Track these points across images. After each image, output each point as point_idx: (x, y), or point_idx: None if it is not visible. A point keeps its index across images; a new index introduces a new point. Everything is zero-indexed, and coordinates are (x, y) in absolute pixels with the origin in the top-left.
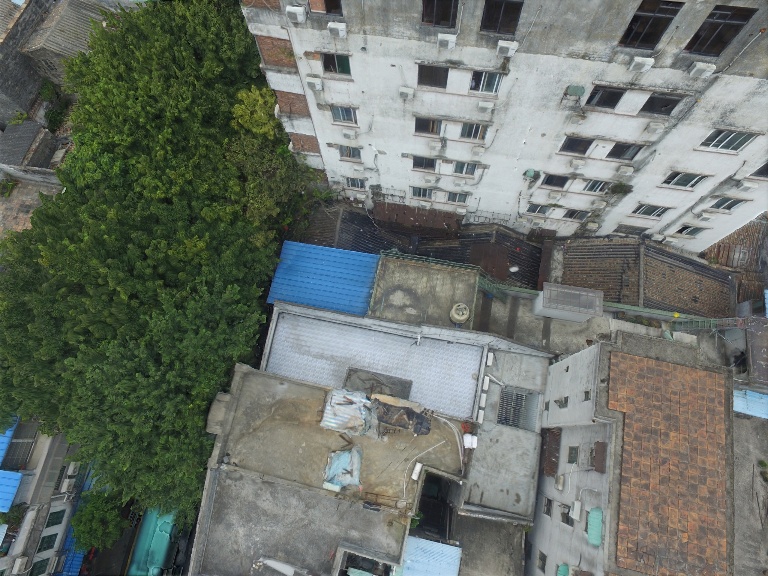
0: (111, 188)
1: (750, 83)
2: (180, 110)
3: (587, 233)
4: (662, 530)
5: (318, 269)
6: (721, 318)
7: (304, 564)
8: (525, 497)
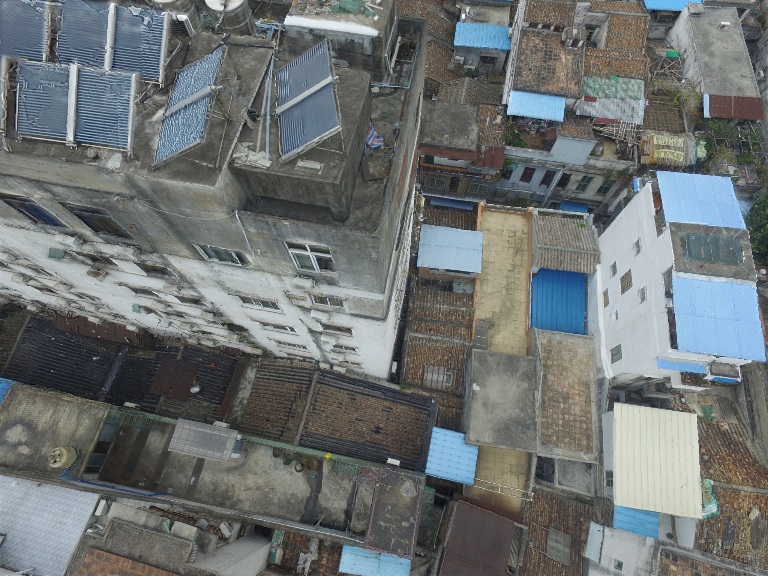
0: None
1: (197, 263)
2: None
3: (267, 354)
4: None
5: None
6: (362, 465)
7: None
8: None
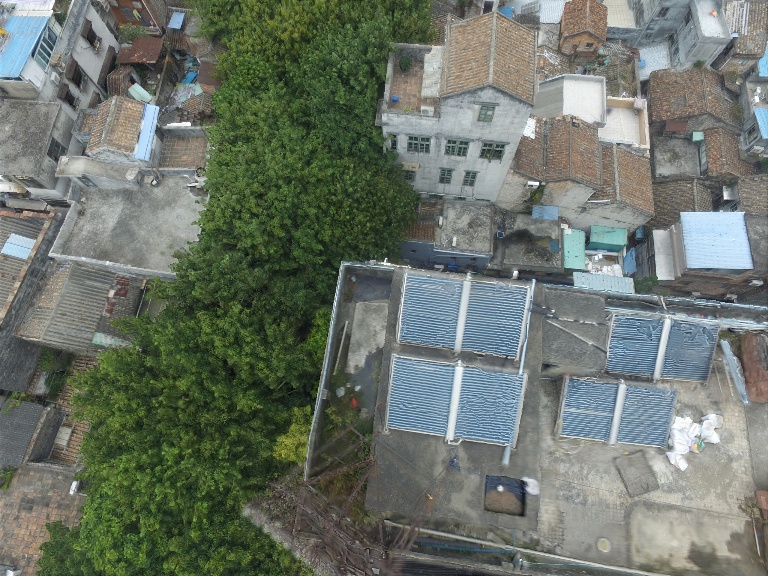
0: (136, 571)
1: None
2: (217, 479)
3: None
4: None
5: None
6: None
7: None
8: None
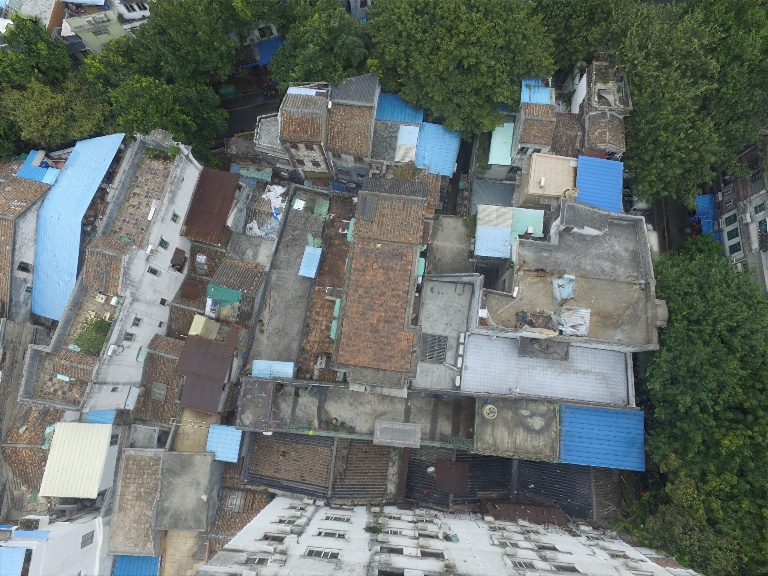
0: None
1: None
2: None
3: None
4: (387, 268)
5: (609, 445)
6: None
7: (573, 235)
8: (428, 291)
